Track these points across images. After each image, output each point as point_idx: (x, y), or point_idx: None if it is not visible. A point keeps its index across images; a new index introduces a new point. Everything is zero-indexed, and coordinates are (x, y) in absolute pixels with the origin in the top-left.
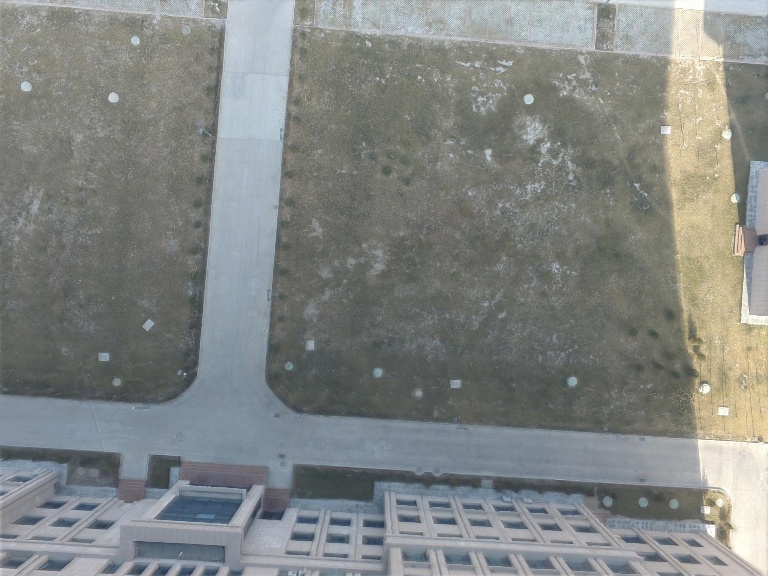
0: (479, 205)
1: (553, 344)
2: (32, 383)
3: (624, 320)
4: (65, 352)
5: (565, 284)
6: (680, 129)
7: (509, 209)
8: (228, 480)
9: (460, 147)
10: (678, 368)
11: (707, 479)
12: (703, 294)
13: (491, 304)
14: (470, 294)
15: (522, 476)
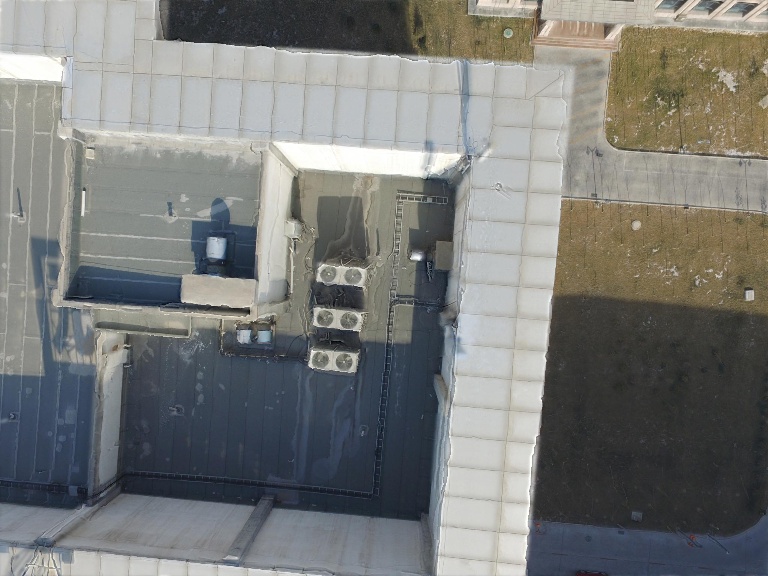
0: None
1: (273, 40)
2: None
3: (347, 14)
4: None
5: None
6: None
7: None
8: None
9: None
10: None
11: None
12: None
13: None
14: None
15: None
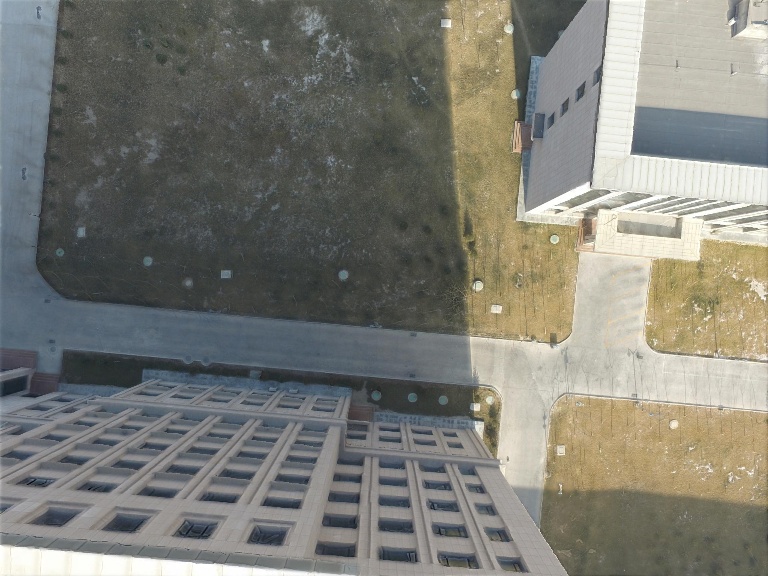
0: (255, 96)
1: (326, 237)
2: None
3: (399, 215)
4: None
5: (340, 178)
6: (461, 23)
7: (285, 101)
8: None
9: (237, 37)
10: (452, 265)
11: (478, 376)
12: (480, 191)
13: (264, 196)
14: (243, 185)
15: (291, 368)
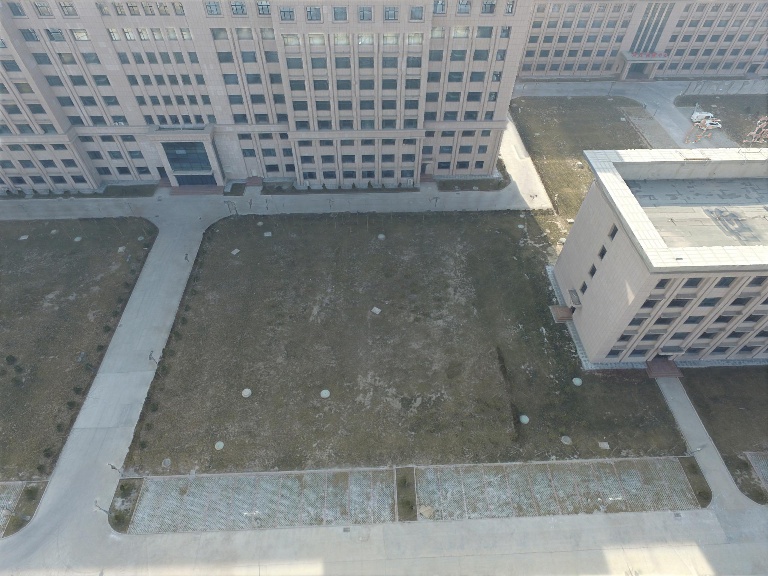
0: None
1: None
2: (315, 220)
3: None
4: (294, 235)
5: None
6: None
7: None
8: (194, 187)
9: None
10: None
11: None
12: None
13: None
14: None
15: (4, 201)
